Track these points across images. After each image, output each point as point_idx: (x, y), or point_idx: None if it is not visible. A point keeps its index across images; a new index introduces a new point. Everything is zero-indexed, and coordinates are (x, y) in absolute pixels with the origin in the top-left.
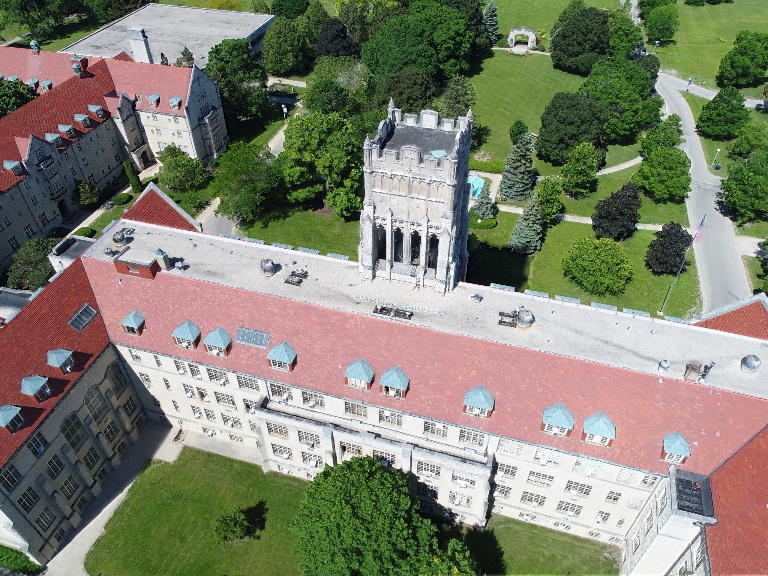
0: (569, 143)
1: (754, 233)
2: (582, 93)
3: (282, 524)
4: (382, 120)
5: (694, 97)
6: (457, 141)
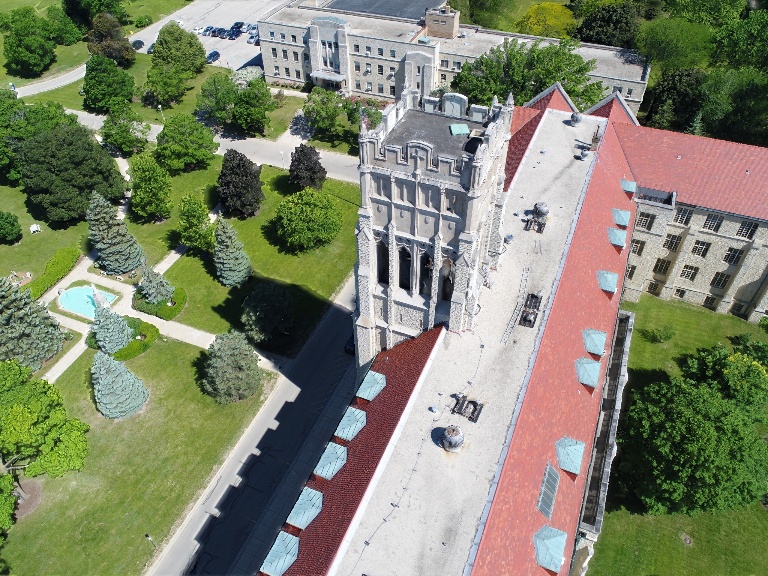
0: (94, 182)
1: (277, 132)
2: (5, 142)
3: (641, 570)
4: (411, 142)
5: (32, 97)
6: (466, 101)
